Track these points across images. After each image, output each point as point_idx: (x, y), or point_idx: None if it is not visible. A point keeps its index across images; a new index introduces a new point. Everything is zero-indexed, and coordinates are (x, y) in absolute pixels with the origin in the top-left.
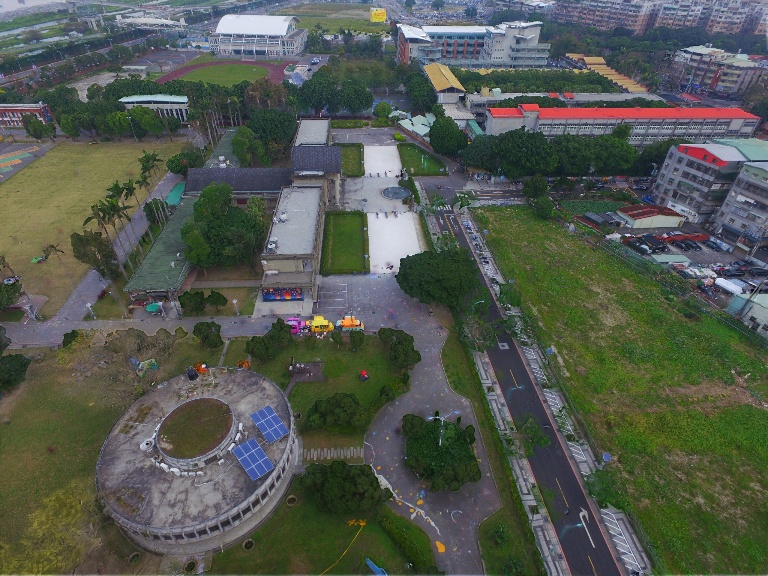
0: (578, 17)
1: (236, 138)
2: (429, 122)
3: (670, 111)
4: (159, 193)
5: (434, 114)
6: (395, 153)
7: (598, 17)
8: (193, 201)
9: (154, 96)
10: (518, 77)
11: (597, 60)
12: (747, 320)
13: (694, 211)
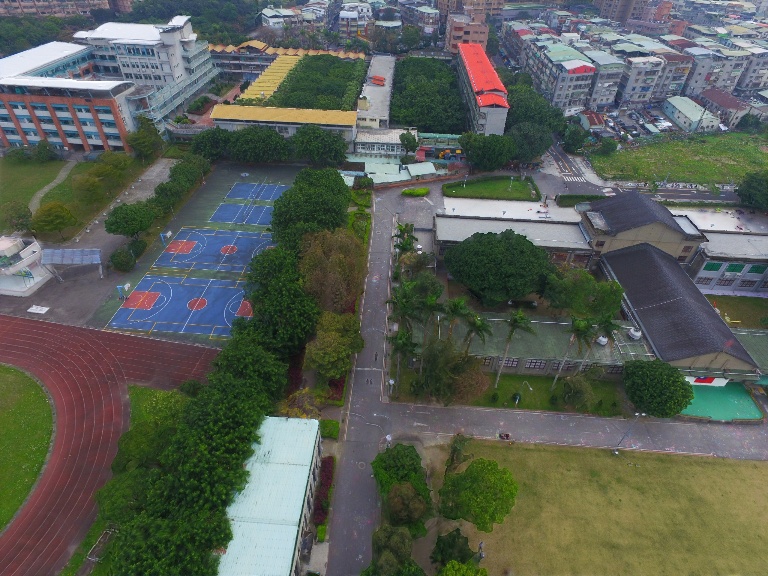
0: (4, 7)
1: (617, 285)
2: (383, 163)
3: (480, 57)
4: (719, 442)
5: (408, 146)
6: (470, 201)
7: (41, 2)
8: (764, 359)
9: (251, 525)
10: (309, 81)
11: (260, 44)
12: (701, 129)
13: (582, 107)
